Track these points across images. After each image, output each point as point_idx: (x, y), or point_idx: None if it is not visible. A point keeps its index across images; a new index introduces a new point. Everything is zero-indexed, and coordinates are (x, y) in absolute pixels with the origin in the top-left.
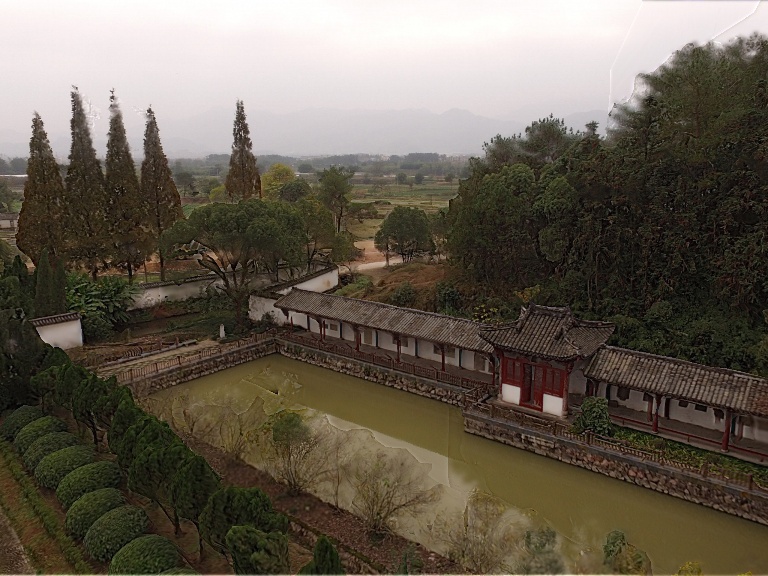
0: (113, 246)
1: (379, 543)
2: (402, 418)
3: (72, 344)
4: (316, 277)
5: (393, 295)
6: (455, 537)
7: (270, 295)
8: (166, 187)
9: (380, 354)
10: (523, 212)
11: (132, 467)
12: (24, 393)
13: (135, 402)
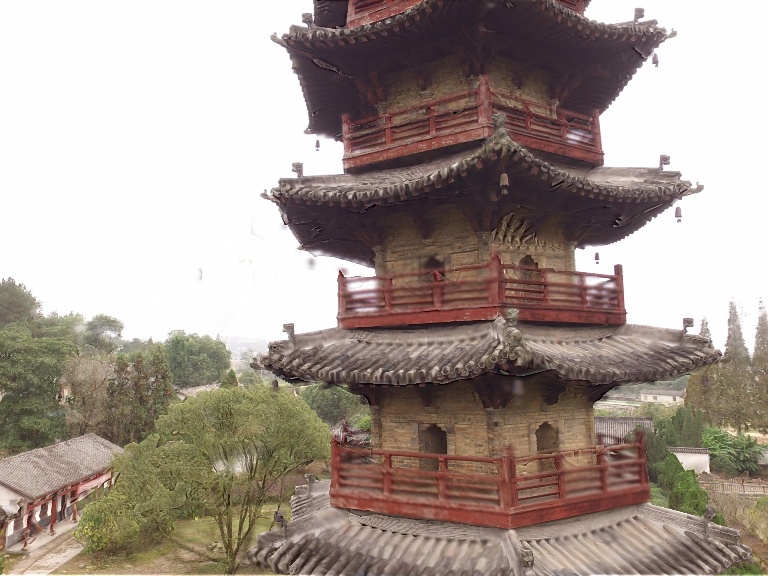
0: (753, 412)
1: None
2: None
3: (701, 470)
4: None
5: None
6: None
7: None
8: None
9: None
10: None
11: (670, 495)
12: (654, 478)
13: (704, 488)
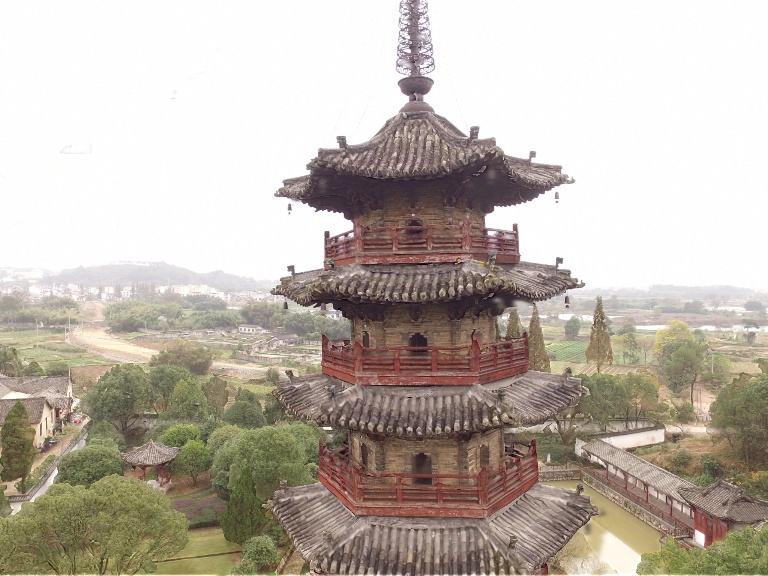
0: None
1: (553, 570)
2: (642, 541)
3: None
4: (639, 432)
5: (673, 457)
6: (583, 575)
7: (587, 440)
8: (541, 355)
9: (643, 495)
10: (765, 412)
11: None
12: None
13: None
